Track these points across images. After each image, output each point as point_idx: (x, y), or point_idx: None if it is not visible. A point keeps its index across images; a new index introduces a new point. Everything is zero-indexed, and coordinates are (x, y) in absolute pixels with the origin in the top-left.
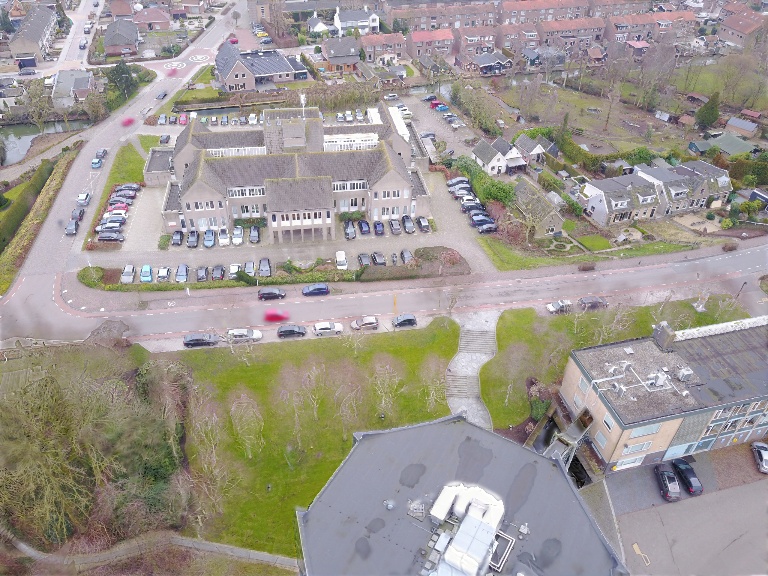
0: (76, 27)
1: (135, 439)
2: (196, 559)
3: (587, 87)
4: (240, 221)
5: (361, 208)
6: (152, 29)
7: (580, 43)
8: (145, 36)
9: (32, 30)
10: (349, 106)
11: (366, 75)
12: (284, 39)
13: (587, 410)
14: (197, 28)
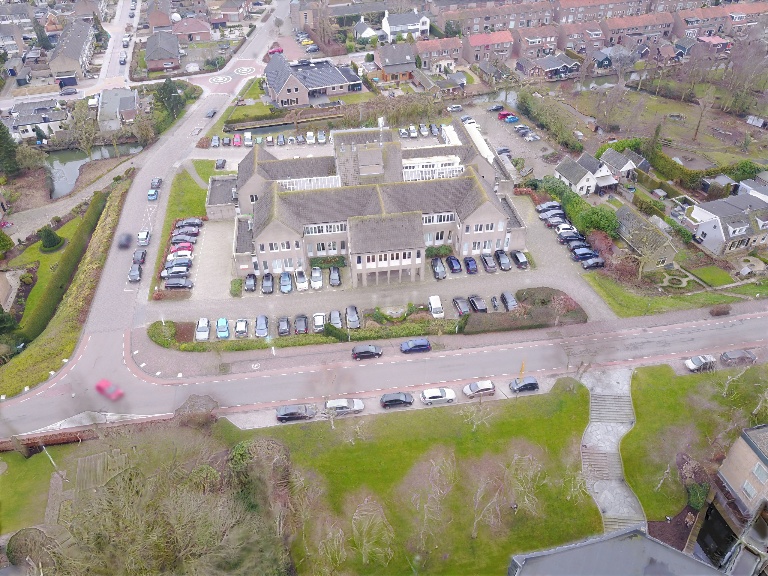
0: (114, 40)
1: (255, 572)
2: None
3: (665, 90)
4: (316, 260)
5: (447, 241)
6: (192, 40)
7: (647, 41)
8: (186, 48)
9: (71, 47)
10: (411, 120)
11: (425, 84)
12: (330, 46)
13: (767, 504)
14: (238, 37)
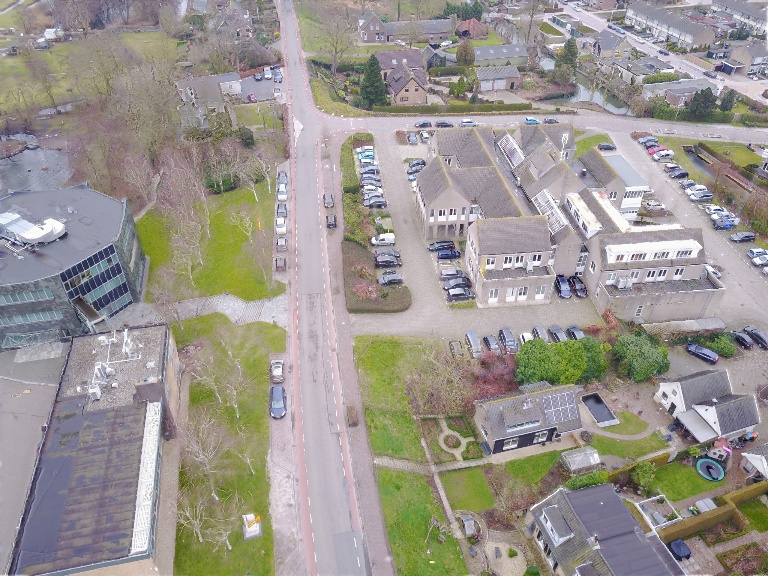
0: None
1: (155, 134)
2: (139, 209)
3: None
4: None
5: None
6: None
7: None
8: None
9: None
10: None
11: None
12: None
13: None
14: None
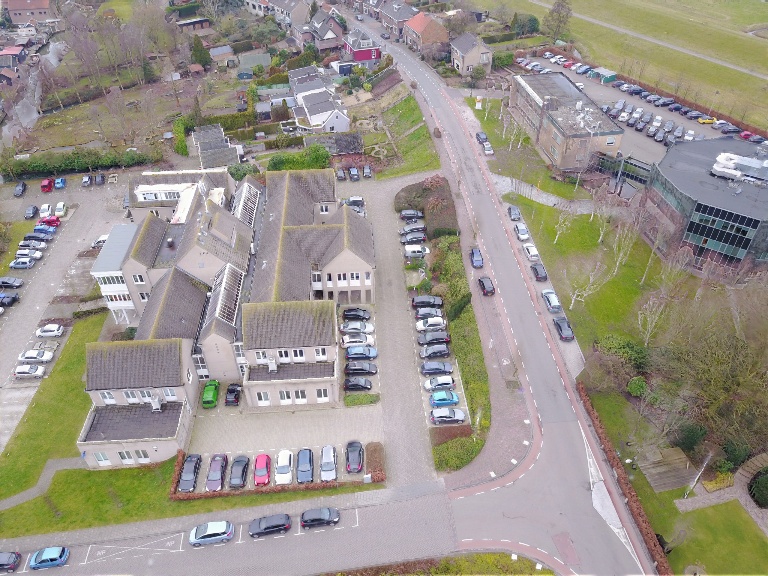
0: None
1: None
2: None
3: (81, 96)
4: None
5: None
6: None
7: None
8: None
9: None
10: None
11: None
12: None
13: (592, 152)
14: None
